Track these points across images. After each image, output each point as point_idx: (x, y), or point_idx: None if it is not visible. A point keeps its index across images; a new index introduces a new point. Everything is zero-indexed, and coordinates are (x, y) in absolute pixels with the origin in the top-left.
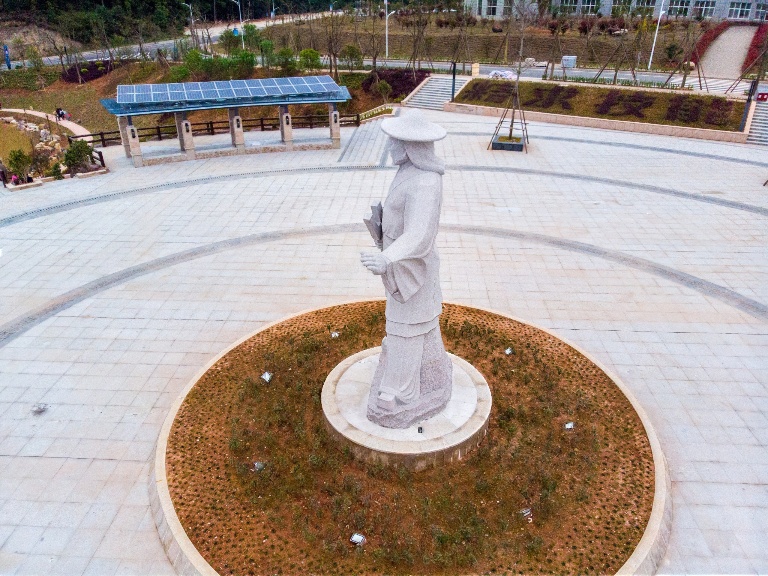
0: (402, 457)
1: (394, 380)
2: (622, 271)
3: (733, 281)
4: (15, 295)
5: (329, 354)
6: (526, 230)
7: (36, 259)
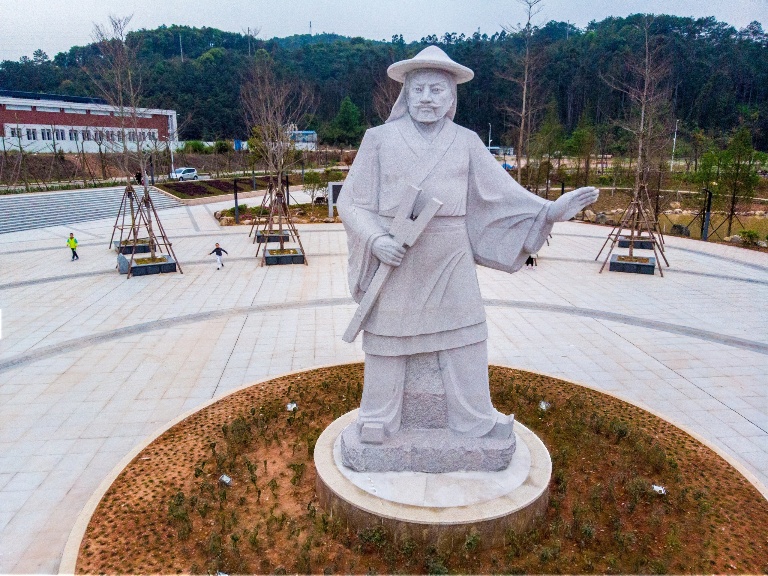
0: None
1: None
2: (89, 353)
3: (148, 316)
4: None
5: (308, 567)
6: None
7: None
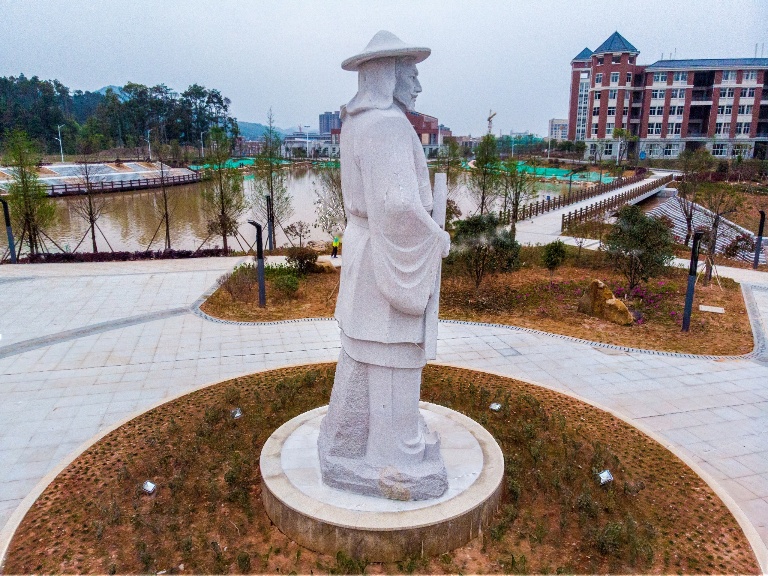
0: None
1: None
2: None
3: None
4: None
5: None
6: None
7: None
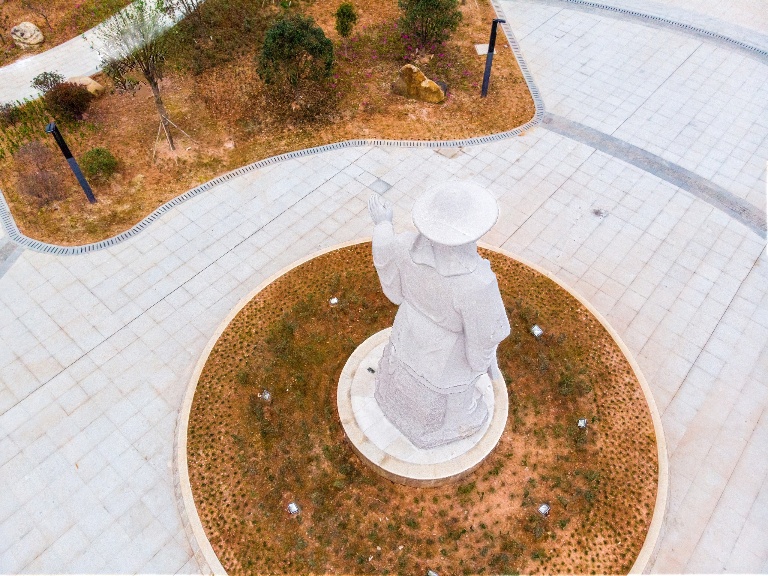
0: None
1: None
2: None
3: None
4: None
5: None
6: None
7: None
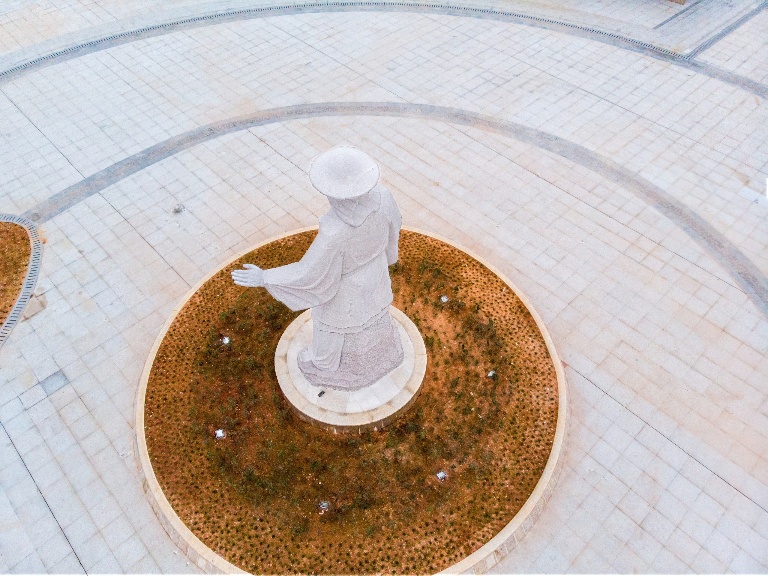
0: (291, 404)
1: (314, 349)
2: None
3: None
4: (243, 95)
5: None
6: (735, 240)
7: (282, 62)
